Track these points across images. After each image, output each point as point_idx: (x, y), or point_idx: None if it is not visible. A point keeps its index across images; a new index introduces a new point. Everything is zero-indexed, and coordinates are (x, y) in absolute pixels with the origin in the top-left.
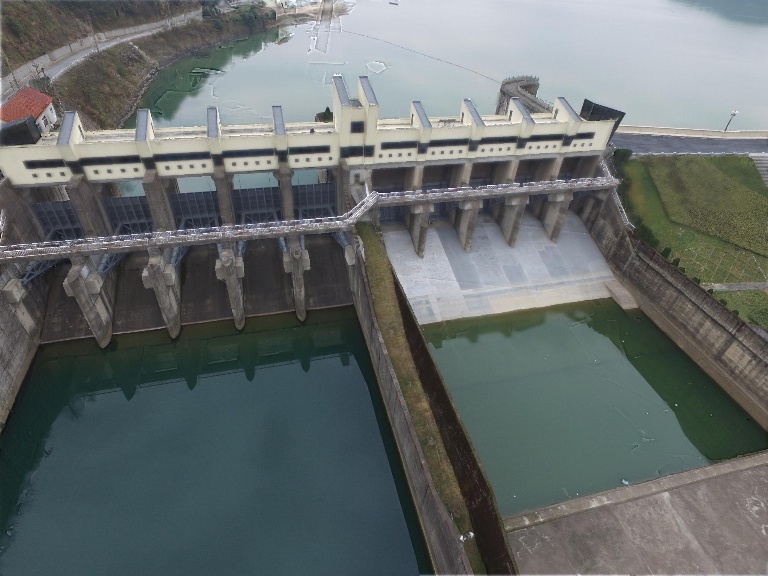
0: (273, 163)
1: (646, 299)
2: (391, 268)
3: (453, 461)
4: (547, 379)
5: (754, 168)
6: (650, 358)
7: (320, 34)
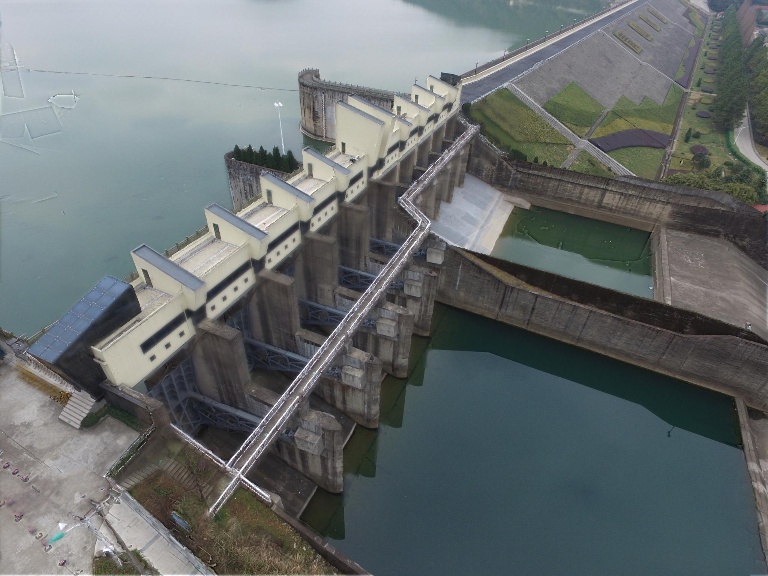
0: (334, 208)
1: (535, 196)
2: (462, 249)
3: (650, 322)
4: (563, 268)
5: (512, 94)
6: (550, 232)
7: (5, 75)
